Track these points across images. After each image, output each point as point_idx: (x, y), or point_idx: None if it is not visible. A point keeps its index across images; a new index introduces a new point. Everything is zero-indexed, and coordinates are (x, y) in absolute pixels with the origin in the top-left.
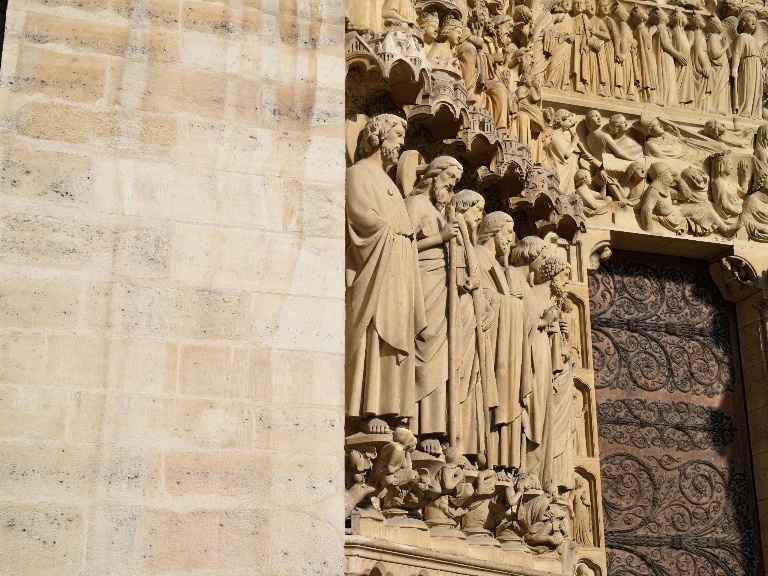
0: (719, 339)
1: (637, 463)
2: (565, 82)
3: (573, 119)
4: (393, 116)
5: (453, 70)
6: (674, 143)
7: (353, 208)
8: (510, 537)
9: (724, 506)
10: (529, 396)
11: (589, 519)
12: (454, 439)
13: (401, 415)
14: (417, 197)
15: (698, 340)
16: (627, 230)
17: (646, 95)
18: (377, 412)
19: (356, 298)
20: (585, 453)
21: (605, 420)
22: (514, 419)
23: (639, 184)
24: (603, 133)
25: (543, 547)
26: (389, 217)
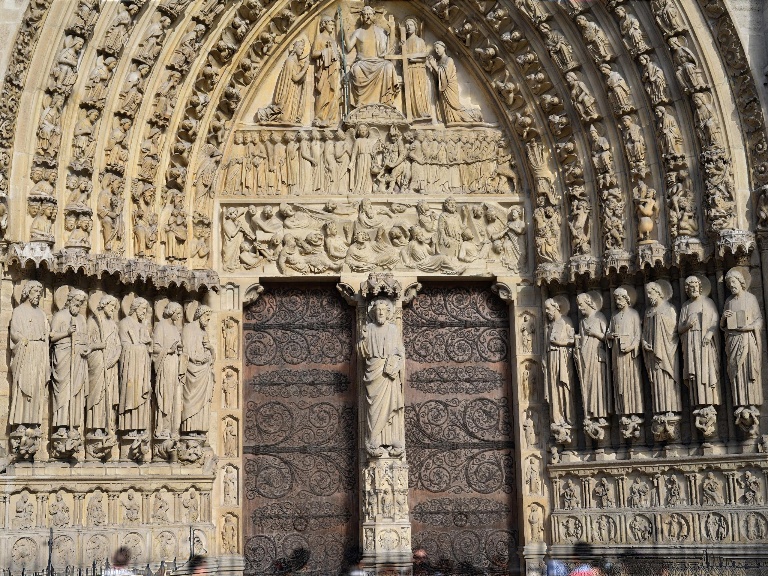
0: (344, 329)
1: (283, 407)
2: (236, 189)
3: (242, 211)
4: (33, 283)
5: (80, 245)
6: (302, 219)
7: (11, 331)
8: (157, 460)
9: (337, 428)
10: (163, 389)
11: (236, 442)
12: (71, 428)
13: (32, 423)
14: (61, 312)
15: (329, 331)
16: (270, 275)
17: (289, 189)
18: (21, 422)
19: (14, 371)
20: (236, 406)
21: (264, 384)
22: (137, 406)
23: (277, 247)
24: (256, 219)
25: (187, 462)
26: (27, 333)
